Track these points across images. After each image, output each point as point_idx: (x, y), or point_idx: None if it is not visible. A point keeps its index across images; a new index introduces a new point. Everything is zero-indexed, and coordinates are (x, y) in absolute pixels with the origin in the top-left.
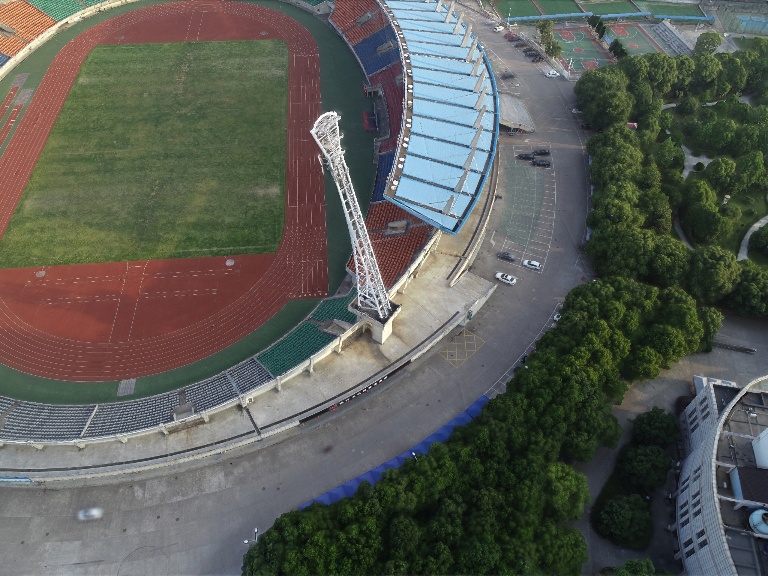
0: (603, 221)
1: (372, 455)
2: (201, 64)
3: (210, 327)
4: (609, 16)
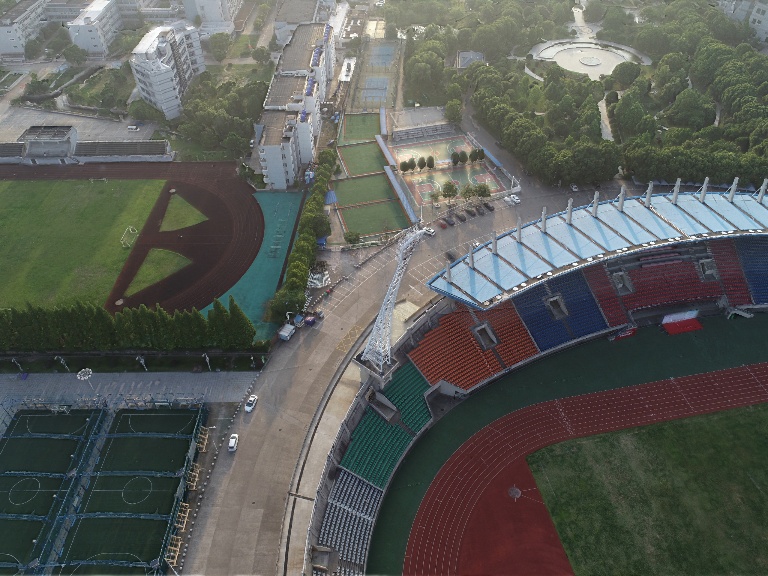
0: (764, 169)
1: None
2: (663, 572)
3: None
4: (390, 157)
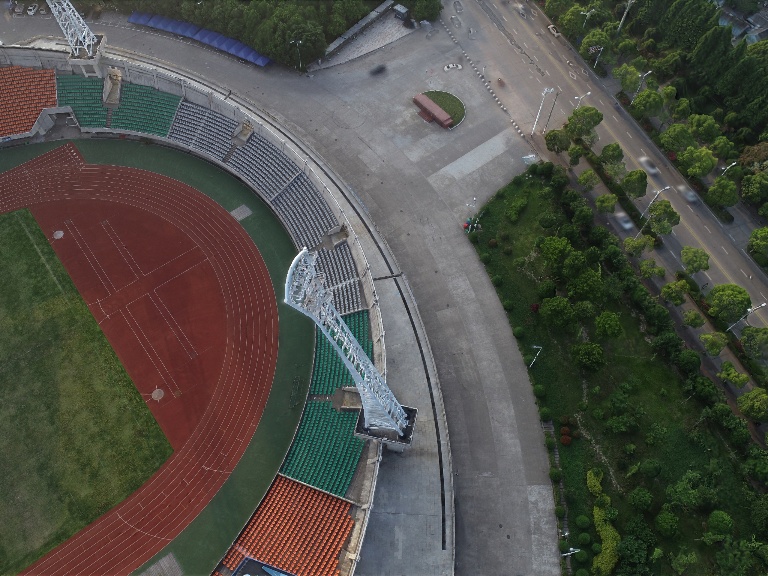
0: None
1: (206, 58)
2: None
3: (149, 199)
4: None
